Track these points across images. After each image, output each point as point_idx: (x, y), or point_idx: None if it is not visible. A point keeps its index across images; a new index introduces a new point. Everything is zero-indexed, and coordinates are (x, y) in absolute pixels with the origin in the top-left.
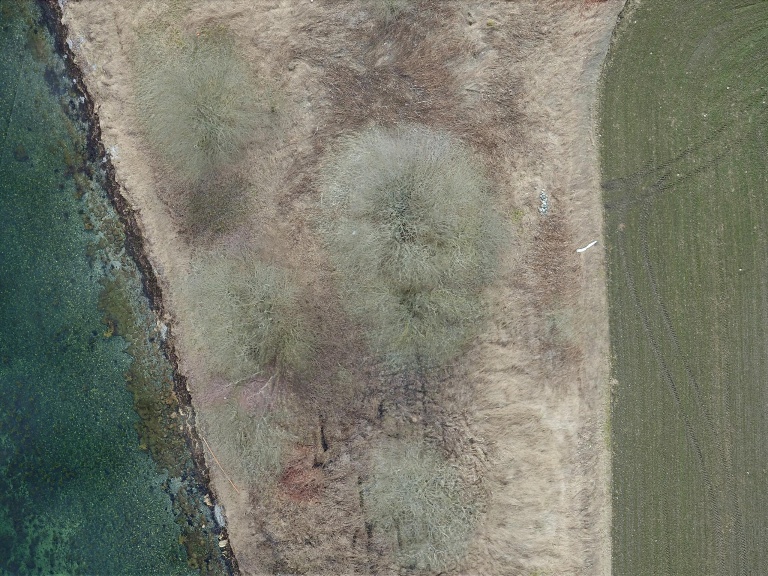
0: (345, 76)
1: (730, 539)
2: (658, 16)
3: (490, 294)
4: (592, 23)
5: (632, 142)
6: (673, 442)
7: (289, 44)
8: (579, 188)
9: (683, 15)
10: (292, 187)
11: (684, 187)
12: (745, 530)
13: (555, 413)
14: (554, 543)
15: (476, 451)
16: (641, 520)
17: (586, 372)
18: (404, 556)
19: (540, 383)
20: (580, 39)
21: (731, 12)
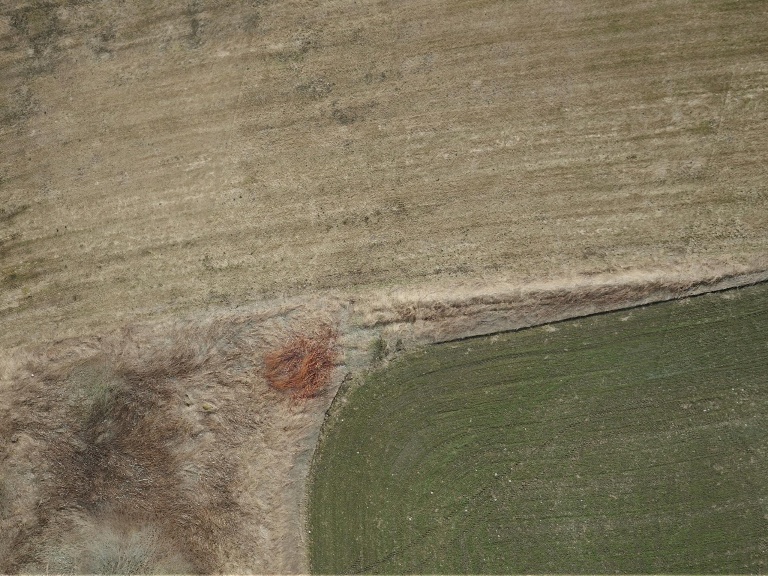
0: (66, 451)
1: None
2: (364, 416)
3: None
4: (300, 419)
5: (340, 541)
6: None
7: (11, 417)
8: None
9: (388, 416)
10: (18, 557)
11: None
12: None
13: None
14: None
15: None
16: None
17: None
18: None
19: None
20: (289, 435)
21: (435, 416)
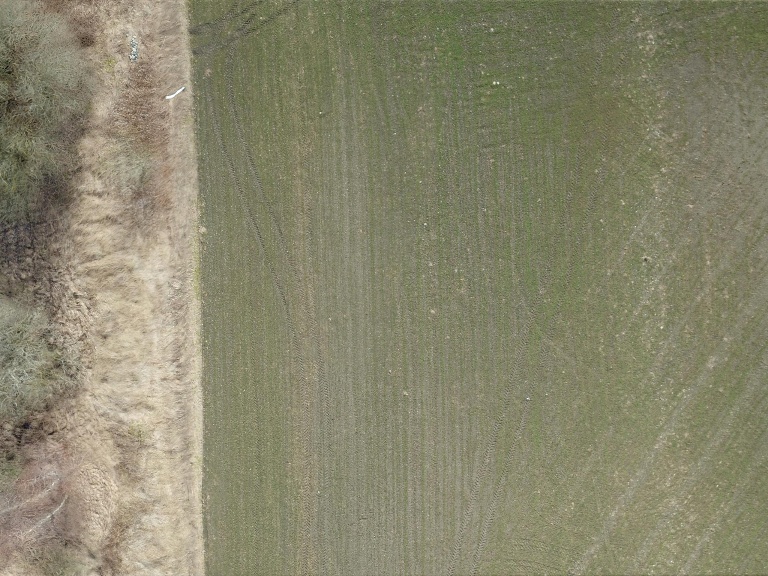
0: None
1: (314, 387)
2: None
3: (86, 145)
4: None
5: None
6: (259, 290)
7: None
8: (168, 34)
9: None
10: None
11: (267, 30)
12: (328, 377)
13: (146, 263)
14: (148, 395)
15: (80, 306)
16: (230, 370)
17: (175, 220)
18: (18, 415)
19: (132, 233)
20: None
21: None
